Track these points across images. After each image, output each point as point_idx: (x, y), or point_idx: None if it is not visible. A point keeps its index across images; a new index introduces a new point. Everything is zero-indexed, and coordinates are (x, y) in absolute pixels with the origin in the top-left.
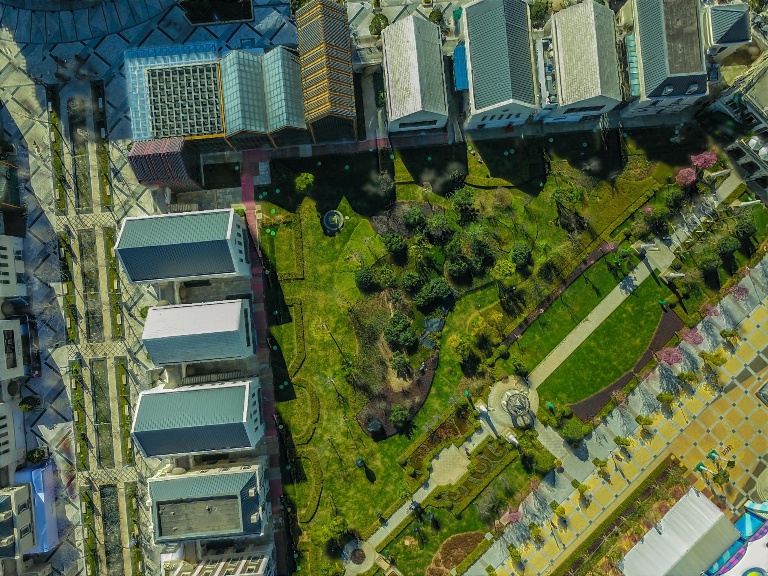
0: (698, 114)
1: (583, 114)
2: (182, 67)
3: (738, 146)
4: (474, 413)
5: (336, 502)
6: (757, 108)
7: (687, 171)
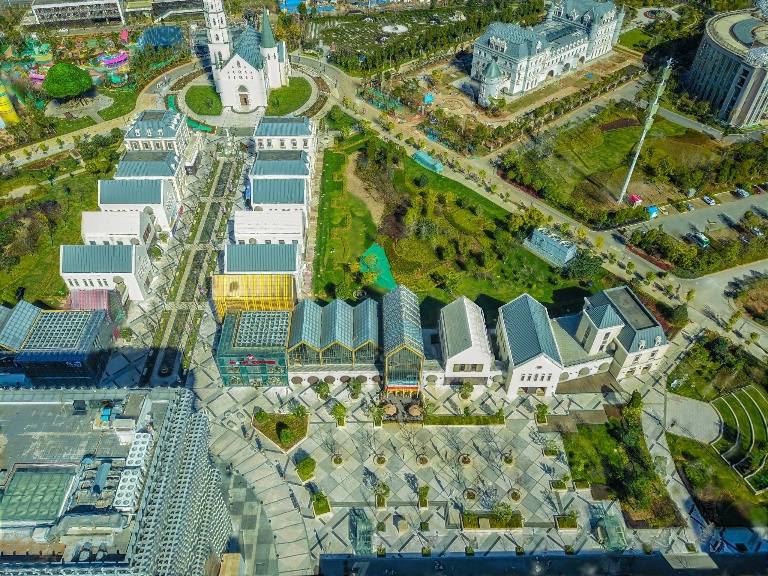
0: None
1: None
2: (48, 349)
3: None
4: None
5: None
6: None
7: None
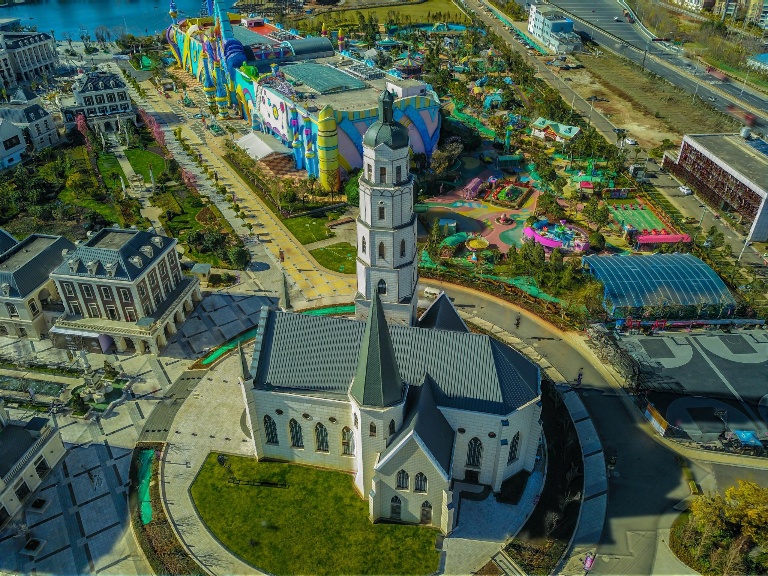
0: (66, 134)
1: (17, 150)
2: None
3: (92, 125)
4: (128, 199)
5: None
6: (74, 106)
7: (78, 122)
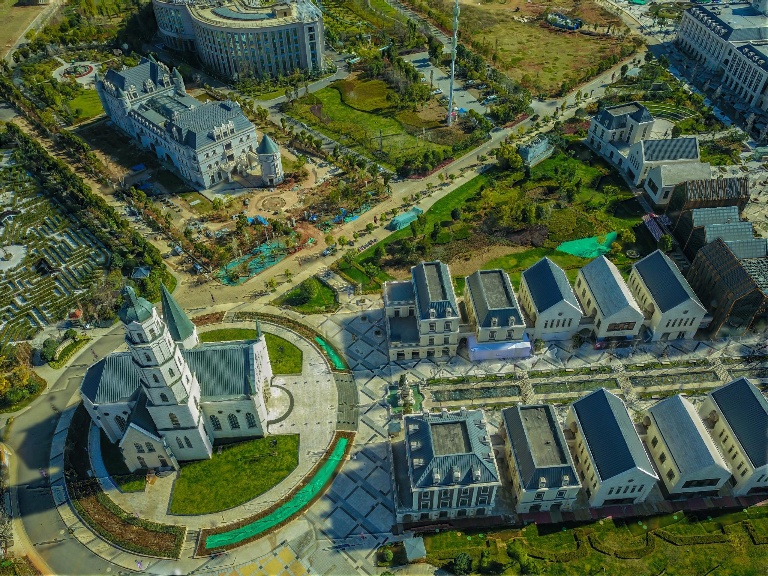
0: None
1: None
2: None
3: None
4: None
5: (541, 575)
6: None
7: None
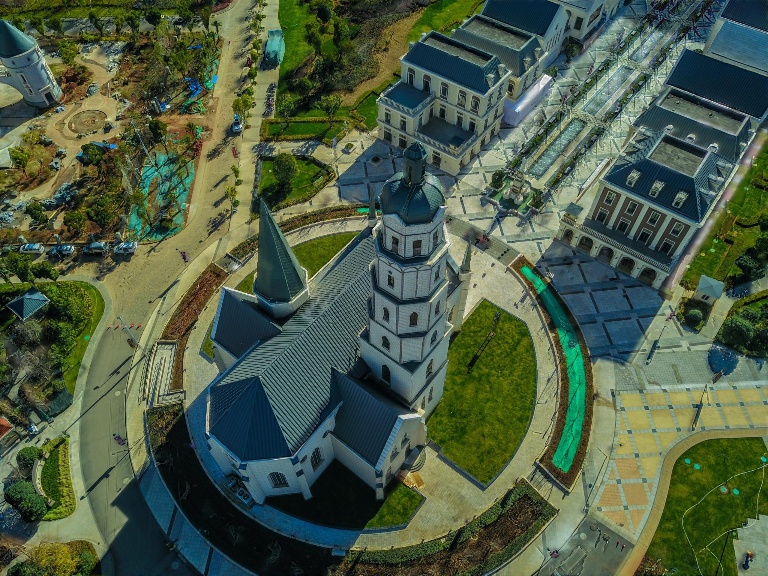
0: None
1: None
2: None
3: None
4: None
5: None
6: None
7: None
